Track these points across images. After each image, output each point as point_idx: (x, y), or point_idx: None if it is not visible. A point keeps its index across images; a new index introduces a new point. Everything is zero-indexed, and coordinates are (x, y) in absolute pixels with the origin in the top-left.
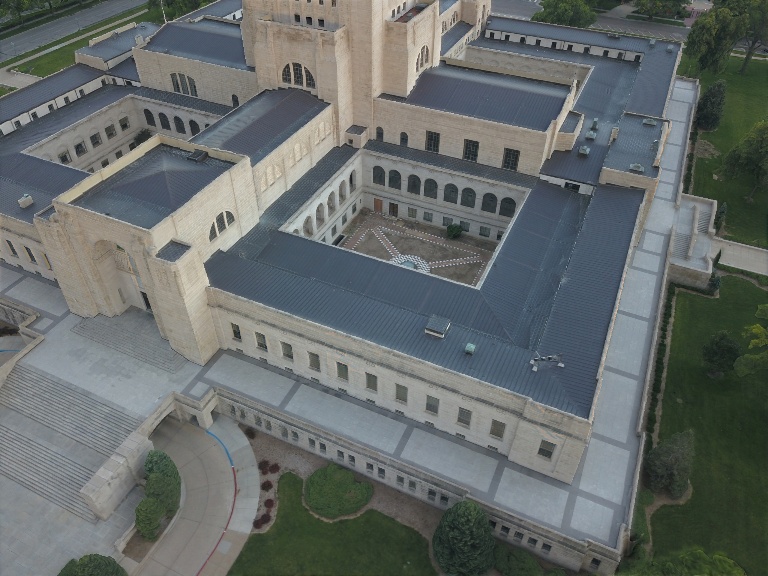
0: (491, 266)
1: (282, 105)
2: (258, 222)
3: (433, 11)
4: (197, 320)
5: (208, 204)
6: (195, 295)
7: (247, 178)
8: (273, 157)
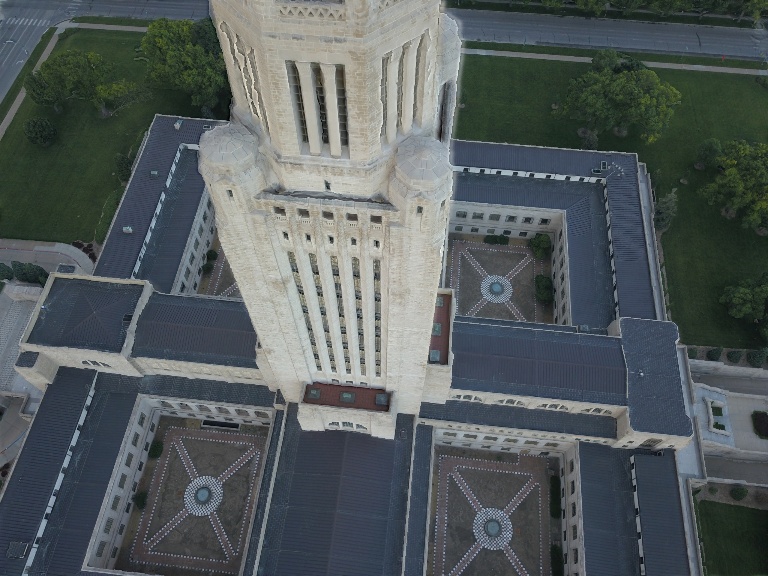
0: (112, 574)
1: (238, 335)
2: (141, 377)
3: (371, 415)
4: (41, 387)
5: (77, 354)
6: (36, 381)
7: (122, 361)
8: (166, 362)
